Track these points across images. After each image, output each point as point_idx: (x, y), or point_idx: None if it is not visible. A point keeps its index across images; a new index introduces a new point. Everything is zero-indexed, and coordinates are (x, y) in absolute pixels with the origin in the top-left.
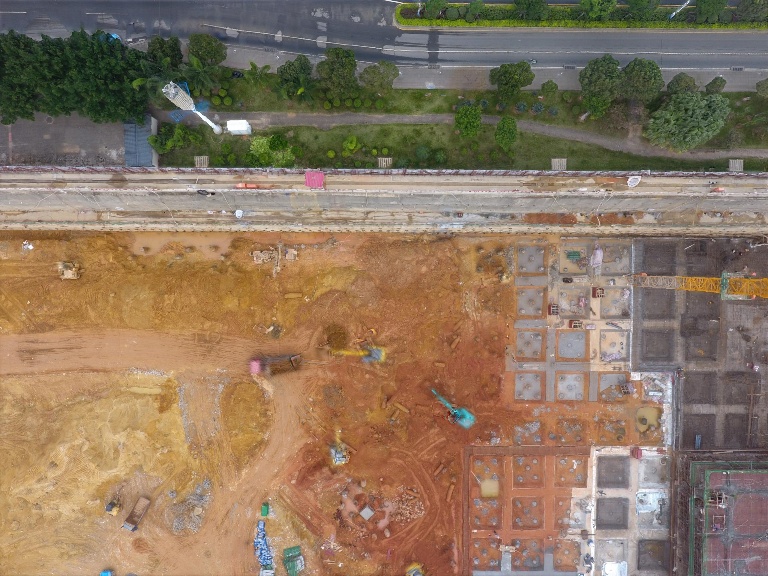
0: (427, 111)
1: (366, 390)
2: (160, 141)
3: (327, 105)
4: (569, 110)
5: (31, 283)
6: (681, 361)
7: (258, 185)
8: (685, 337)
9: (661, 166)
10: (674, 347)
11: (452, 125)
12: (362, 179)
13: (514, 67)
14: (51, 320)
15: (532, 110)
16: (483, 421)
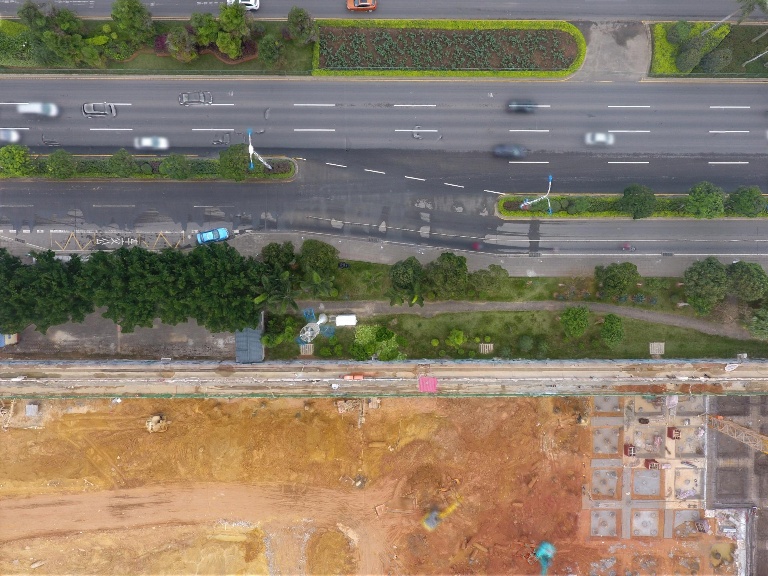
0: (528, 298)
1: (450, 538)
2: (272, 341)
3: (432, 296)
4: (667, 297)
5: (119, 436)
6: (755, 498)
7: (363, 373)
8: (759, 475)
9: (757, 349)
10: (748, 485)
11: (553, 312)
12: (465, 366)
13: (622, 270)
14: (141, 475)
15: (633, 300)
16: (559, 558)
